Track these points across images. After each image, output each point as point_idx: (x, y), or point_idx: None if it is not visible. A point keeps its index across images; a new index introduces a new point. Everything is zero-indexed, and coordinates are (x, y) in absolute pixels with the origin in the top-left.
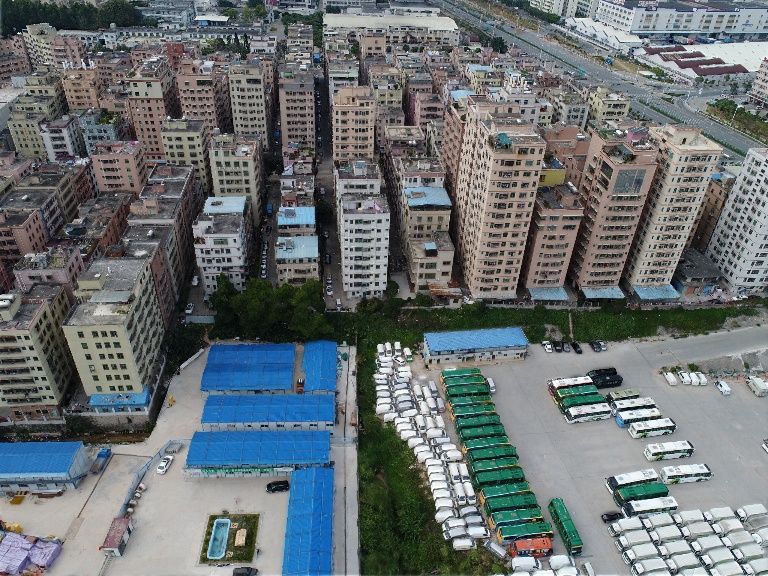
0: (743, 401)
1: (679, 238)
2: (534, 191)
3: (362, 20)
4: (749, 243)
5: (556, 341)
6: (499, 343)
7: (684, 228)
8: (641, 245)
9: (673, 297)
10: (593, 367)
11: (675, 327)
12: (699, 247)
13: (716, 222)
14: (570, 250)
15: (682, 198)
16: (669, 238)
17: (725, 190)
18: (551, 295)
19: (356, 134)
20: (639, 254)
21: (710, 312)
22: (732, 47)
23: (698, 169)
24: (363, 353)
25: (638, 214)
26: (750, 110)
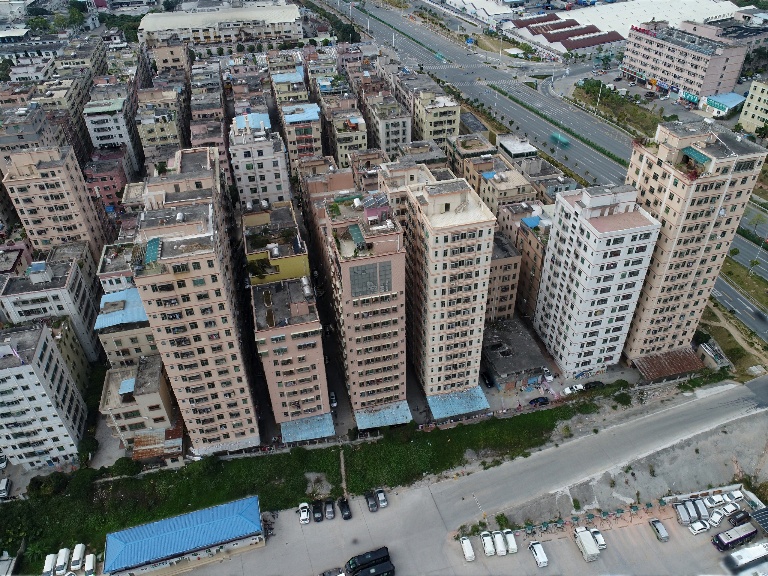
0: (565, 575)
1: (472, 333)
2: (226, 315)
3: (187, 19)
4: (572, 321)
5: (318, 501)
6: (215, 536)
7: (474, 321)
8: (424, 347)
9: (479, 409)
10: (362, 543)
11: (488, 447)
12: (527, 313)
13: (538, 284)
14: (321, 371)
15: (458, 287)
16: (457, 336)
17: (541, 244)
18: (310, 431)
19: (53, 213)
20: (425, 357)
21: (534, 417)
22: (610, 9)
23: (468, 249)
24: (20, 575)
25: (401, 315)
26: (620, 89)
